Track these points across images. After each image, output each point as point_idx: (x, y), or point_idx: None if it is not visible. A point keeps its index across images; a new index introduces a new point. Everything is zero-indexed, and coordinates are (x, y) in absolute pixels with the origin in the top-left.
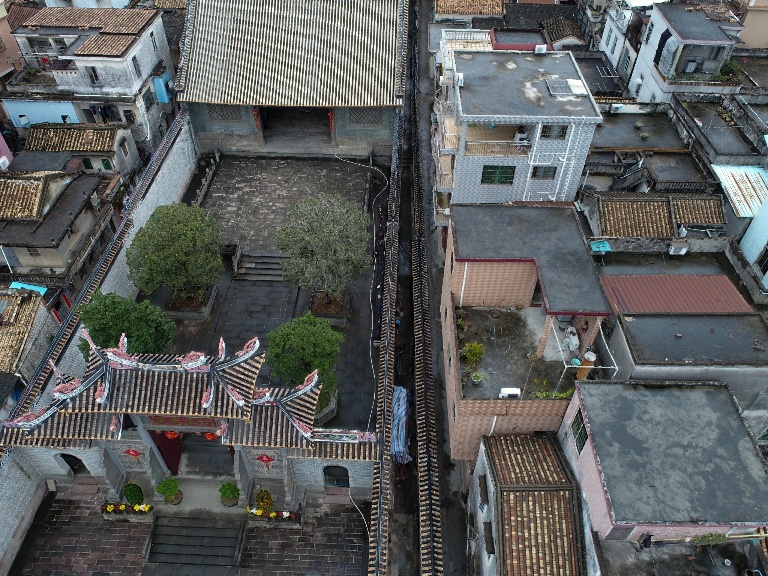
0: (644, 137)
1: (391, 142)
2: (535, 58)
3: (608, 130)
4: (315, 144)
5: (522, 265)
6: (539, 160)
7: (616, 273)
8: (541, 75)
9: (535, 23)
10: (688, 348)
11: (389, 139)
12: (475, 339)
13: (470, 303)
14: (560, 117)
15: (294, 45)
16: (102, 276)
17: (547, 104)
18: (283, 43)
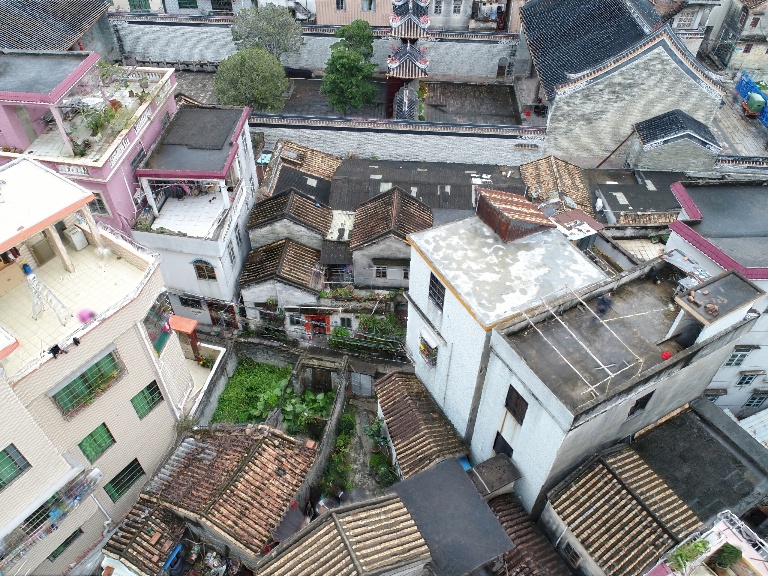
0: None
1: (104, 52)
2: None
3: None
4: None
5: None
6: None
7: None
8: None
9: None
10: None
11: (103, 50)
12: None
13: None
14: None
15: (2, 9)
16: None
17: None
18: None
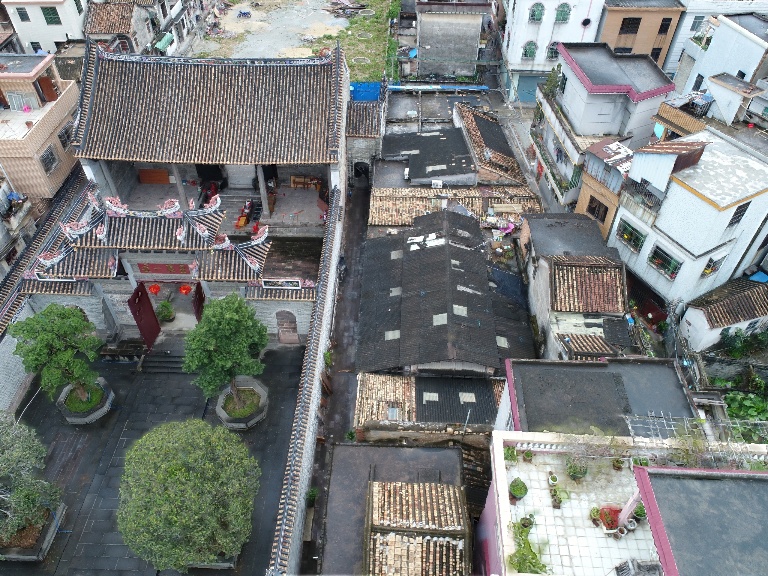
0: None
1: None
2: None
3: None
4: None
5: None
6: None
7: None
8: None
9: None
10: None
11: None
12: None
13: None
14: None
15: None
16: (288, 457)
17: None
18: None
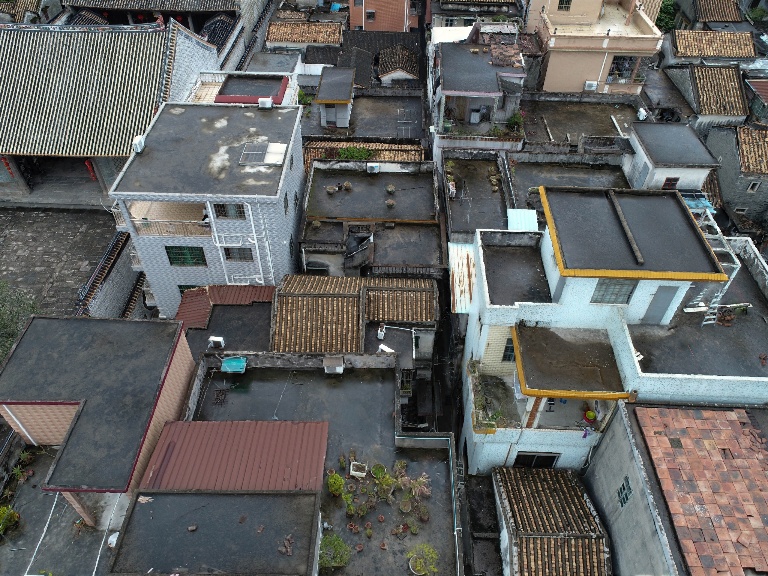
0: (388, 205)
1: None
2: (256, 113)
3: (354, 195)
4: (87, 193)
5: (78, 405)
6: (227, 241)
7: (248, 399)
8: (247, 136)
9: (370, 53)
10: (192, 550)
11: None
12: (28, 495)
13: (48, 441)
14: (227, 196)
15: (46, 85)
16: None
17: (227, 177)
18: (34, 82)
